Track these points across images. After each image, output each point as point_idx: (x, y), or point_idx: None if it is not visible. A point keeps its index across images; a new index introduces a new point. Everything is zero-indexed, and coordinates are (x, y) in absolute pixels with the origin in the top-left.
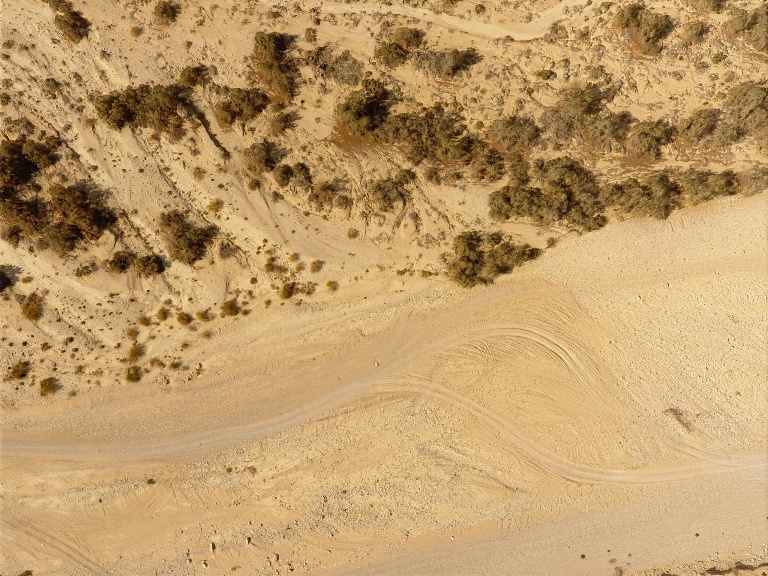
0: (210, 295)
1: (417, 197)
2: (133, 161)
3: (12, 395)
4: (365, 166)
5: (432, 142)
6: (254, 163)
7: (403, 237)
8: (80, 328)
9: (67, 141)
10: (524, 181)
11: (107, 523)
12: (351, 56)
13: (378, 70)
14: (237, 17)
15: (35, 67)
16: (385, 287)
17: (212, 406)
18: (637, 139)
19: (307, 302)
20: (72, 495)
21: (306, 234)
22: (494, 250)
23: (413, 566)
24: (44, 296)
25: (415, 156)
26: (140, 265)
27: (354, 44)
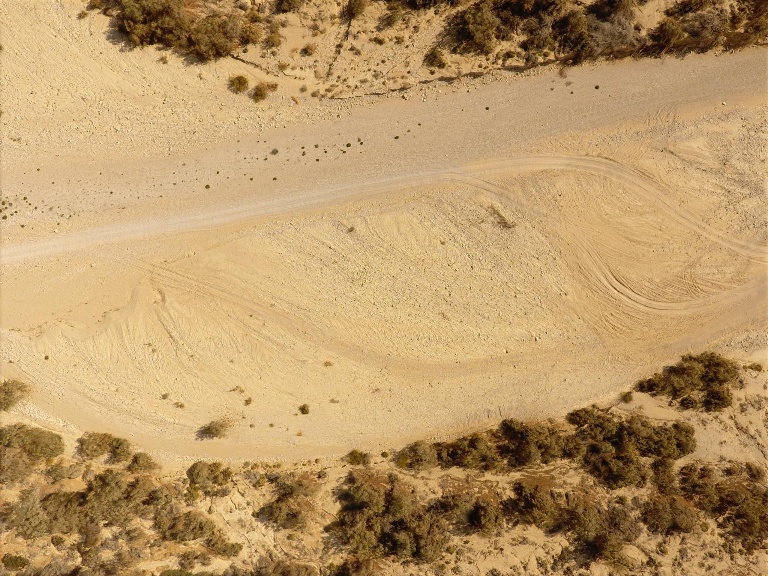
0: None
1: None
2: None
3: None
4: None
5: (761, 511)
6: None
7: None
8: None
9: None
10: (661, 465)
11: None
12: None
13: None
14: None
15: None
16: None
17: None
18: None
19: None
20: None
21: None
22: None
23: (764, 77)
24: None
25: None
26: None
27: None
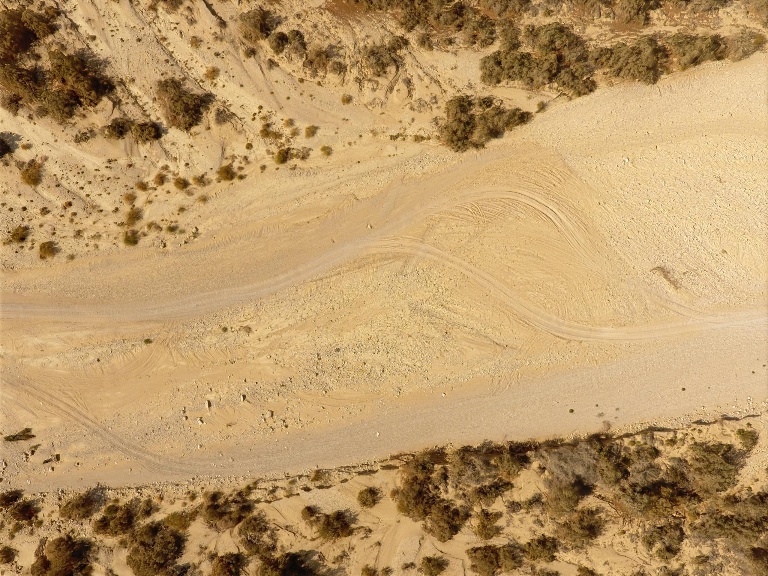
0: (206, 160)
1: (410, 62)
2: (131, 31)
3: (12, 258)
4: (359, 33)
5: (424, 7)
6: (250, 29)
7: (396, 102)
8: (78, 193)
9: (66, 12)
10: (515, 45)
11: (105, 382)
12: None
13: None
14: None
15: None
16: (378, 152)
17: (208, 268)
18: (626, 1)
19: (301, 167)
20: (71, 355)
21: (301, 100)
22: (485, 112)
23: (405, 422)
24: (43, 162)
25: (408, 21)
26: (137, 129)
27: None
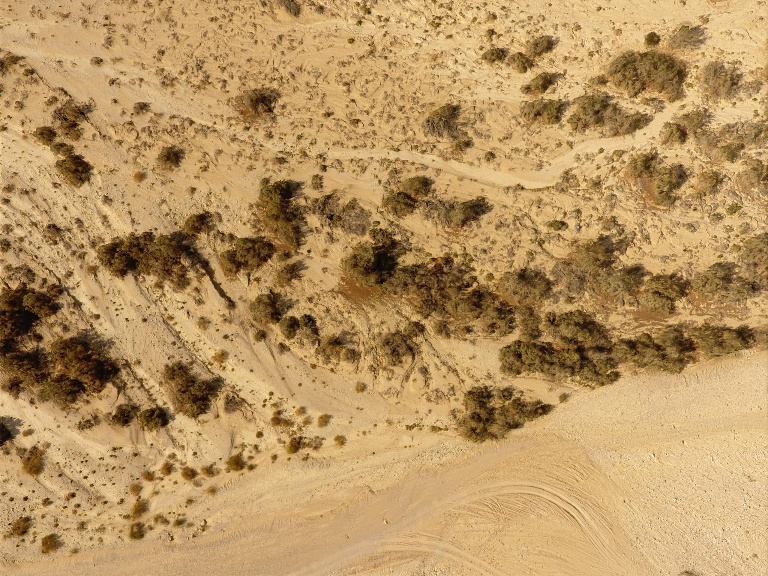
0: (215, 450)
1: (426, 351)
2: (136, 310)
3: (13, 552)
4: (373, 318)
5: (441, 296)
6: None
7: (412, 392)
8: (82, 483)
9: (69, 289)
10: (536, 337)
11: None
12: (358, 205)
13: (386, 219)
14: (242, 163)
15: (36, 212)
16: (394, 442)
17: (217, 564)
18: (651, 296)
19: (314, 457)
20: None
21: (313, 387)
22: (505, 408)
23: None
24: (45, 449)
25: (424, 310)
26: (143, 421)
27: (361, 192)
